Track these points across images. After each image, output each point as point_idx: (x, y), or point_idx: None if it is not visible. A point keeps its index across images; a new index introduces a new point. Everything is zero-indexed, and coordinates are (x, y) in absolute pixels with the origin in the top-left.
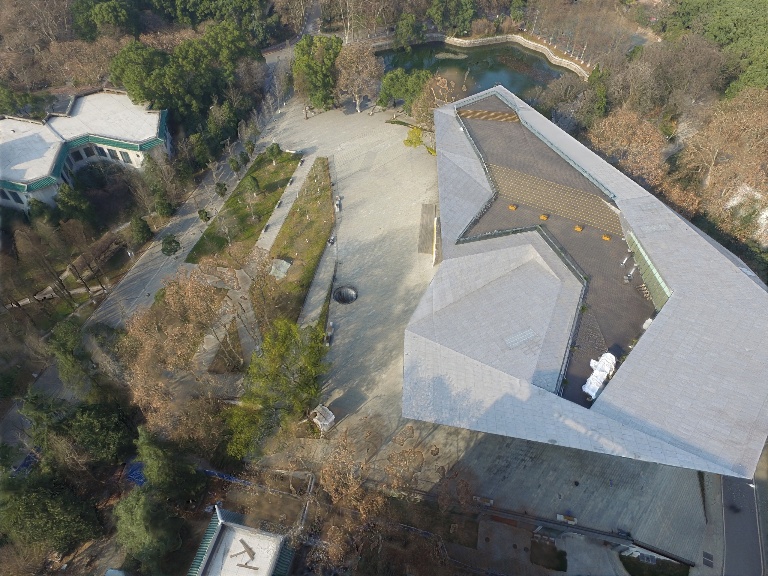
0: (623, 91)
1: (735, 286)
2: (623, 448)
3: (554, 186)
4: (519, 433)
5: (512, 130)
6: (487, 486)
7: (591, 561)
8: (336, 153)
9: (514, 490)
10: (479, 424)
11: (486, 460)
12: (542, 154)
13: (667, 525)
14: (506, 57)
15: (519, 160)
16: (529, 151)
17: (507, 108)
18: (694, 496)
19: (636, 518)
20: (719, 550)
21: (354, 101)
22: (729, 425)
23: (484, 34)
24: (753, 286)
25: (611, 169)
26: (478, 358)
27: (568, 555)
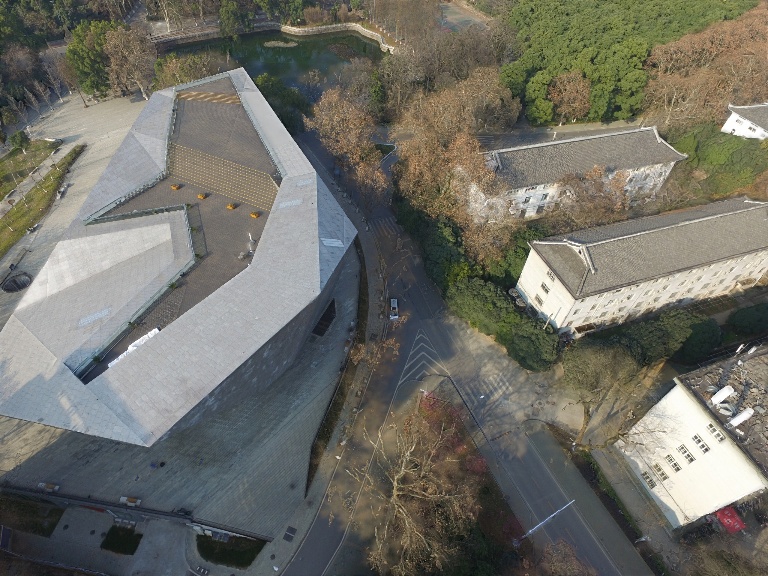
0: (393, 74)
1: (300, 257)
2: (83, 423)
3: (229, 165)
4: (23, 414)
5: (226, 111)
6: (63, 472)
7: (165, 543)
8: (99, 141)
9: (90, 474)
10: (1, 407)
11: (77, 445)
12: (240, 134)
13: (248, 502)
14: (337, 45)
15: (211, 140)
16: (228, 131)
17: (231, 89)
18: (298, 471)
19: (208, 496)
20: (306, 524)
21: (129, 88)
22: (178, 394)
23: (322, 22)
24: (314, 256)
25: (294, 147)
26: (43, 339)
27: (143, 538)
